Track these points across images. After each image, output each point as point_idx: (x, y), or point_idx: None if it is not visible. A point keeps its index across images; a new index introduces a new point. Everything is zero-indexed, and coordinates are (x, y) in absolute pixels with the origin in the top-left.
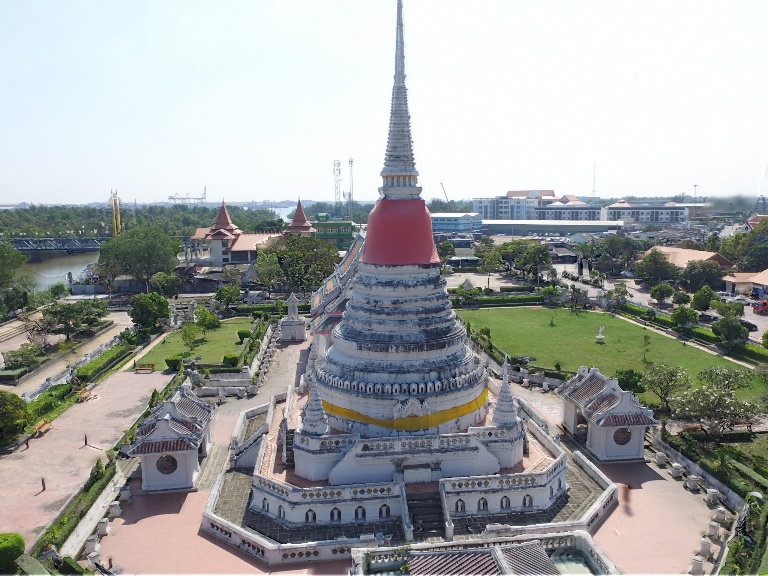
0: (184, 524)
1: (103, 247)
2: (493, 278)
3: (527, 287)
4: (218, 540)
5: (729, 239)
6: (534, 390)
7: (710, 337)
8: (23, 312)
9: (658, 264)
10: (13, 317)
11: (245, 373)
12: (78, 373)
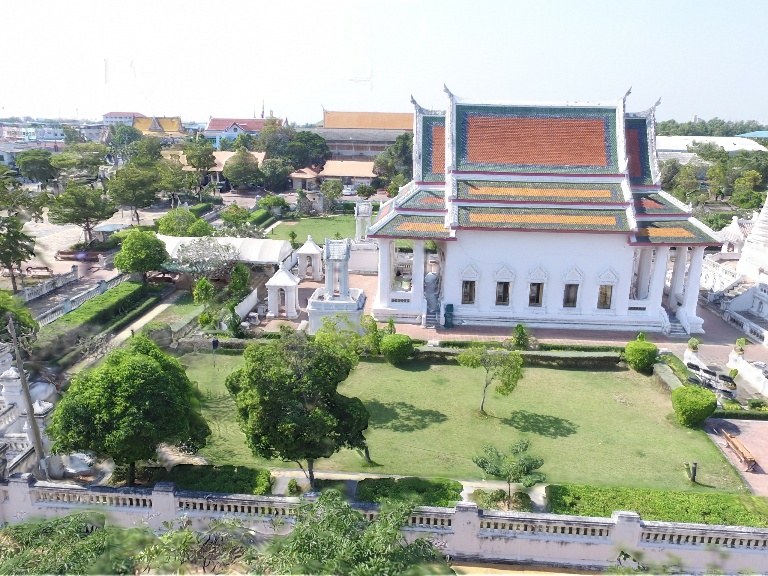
0: None
1: None
2: (47, 209)
3: (207, 205)
4: None
5: (228, 141)
6: None
7: None
8: None
9: (256, 166)
10: None
11: None
12: None
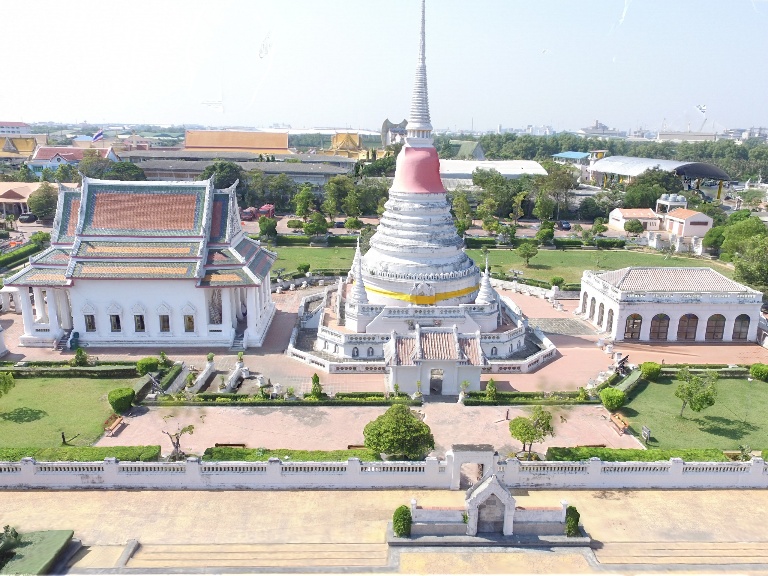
0: (523, 378)
1: None
2: None
3: None
4: (538, 368)
5: (50, 170)
6: (304, 289)
7: (254, 238)
8: None
9: None
10: None
11: (185, 368)
12: (148, 453)
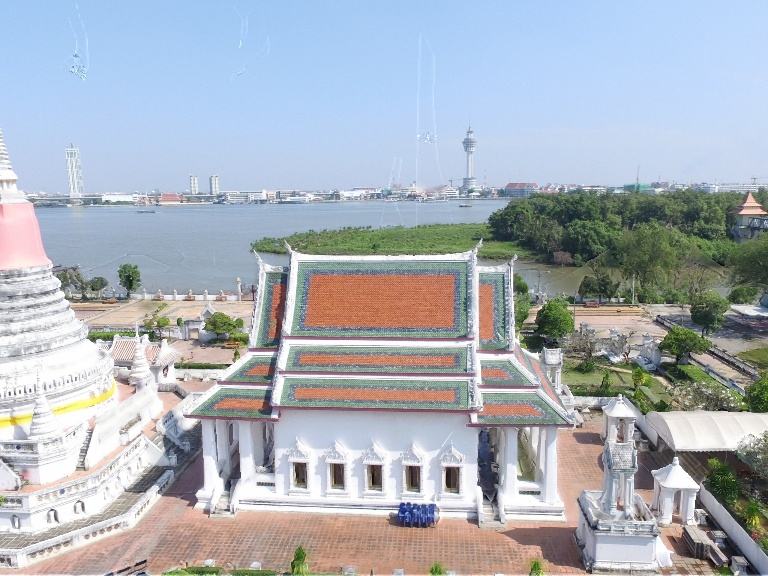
0: None
1: (734, 247)
2: None
3: None
4: None
5: None
6: None
7: None
8: (610, 302)
9: None
10: (584, 302)
11: None
12: None
